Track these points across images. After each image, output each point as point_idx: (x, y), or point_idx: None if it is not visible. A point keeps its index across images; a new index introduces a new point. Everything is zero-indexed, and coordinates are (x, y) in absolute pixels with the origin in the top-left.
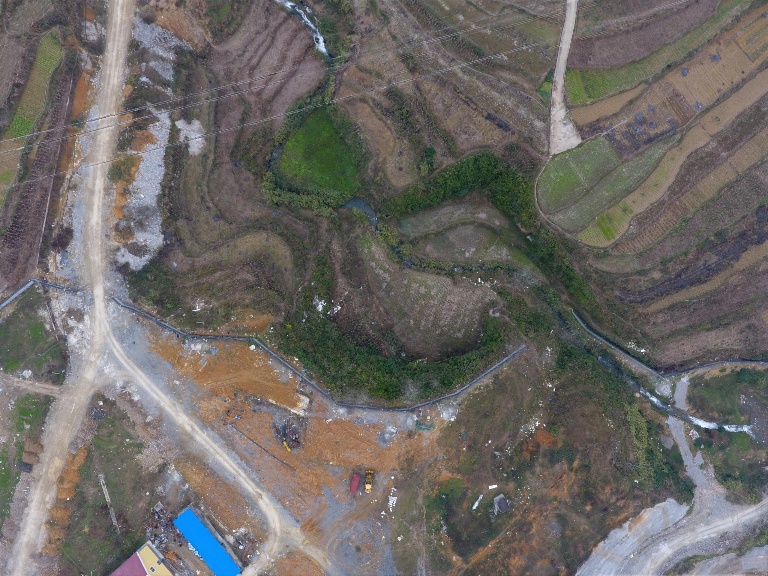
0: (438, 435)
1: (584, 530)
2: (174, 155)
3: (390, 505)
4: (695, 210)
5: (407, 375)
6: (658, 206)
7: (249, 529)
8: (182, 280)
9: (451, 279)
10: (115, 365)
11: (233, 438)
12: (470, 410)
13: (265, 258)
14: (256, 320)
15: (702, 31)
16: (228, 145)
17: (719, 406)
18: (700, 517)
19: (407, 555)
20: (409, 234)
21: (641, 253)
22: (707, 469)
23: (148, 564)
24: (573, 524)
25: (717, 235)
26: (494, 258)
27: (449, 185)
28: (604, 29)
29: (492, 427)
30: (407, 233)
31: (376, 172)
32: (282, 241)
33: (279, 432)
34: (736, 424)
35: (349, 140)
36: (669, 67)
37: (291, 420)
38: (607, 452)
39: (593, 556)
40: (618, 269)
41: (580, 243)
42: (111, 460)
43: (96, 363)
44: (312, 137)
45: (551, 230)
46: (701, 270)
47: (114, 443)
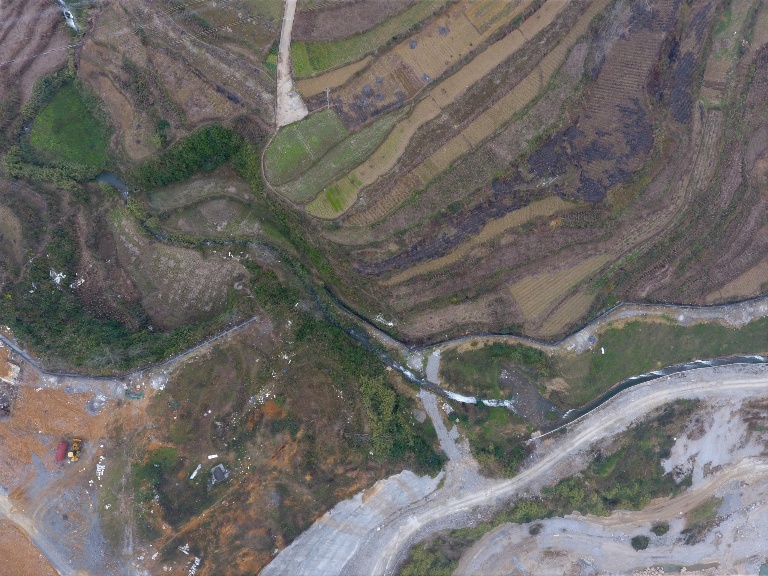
0: (147, 404)
1: (307, 500)
2: None
3: (98, 473)
4: (427, 182)
5: (121, 345)
6: (389, 178)
7: None
8: None
9: (200, 253)
10: None
11: None
12: (182, 379)
13: None
14: None
15: (428, 3)
16: None
17: (477, 381)
18: (452, 491)
19: (114, 523)
20: (159, 208)
21: (373, 225)
22: (462, 443)
23: None
24: (295, 494)
25: (450, 207)
26: (246, 232)
27: (187, 158)
28: (326, 1)
29: (211, 397)
30: (157, 207)
31: (117, 145)
32: (12, 213)
33: None
34: (496, 399)
35: (95, 114)
36: (395, 39)
37: (2, 389)
38: (334, 423)
39: (315, 526)
40: (351, 241)
41: (309, 215)
42: None
43: None
44: (62, 111)
45: (279, 202)
46: (440, 243)
47: None
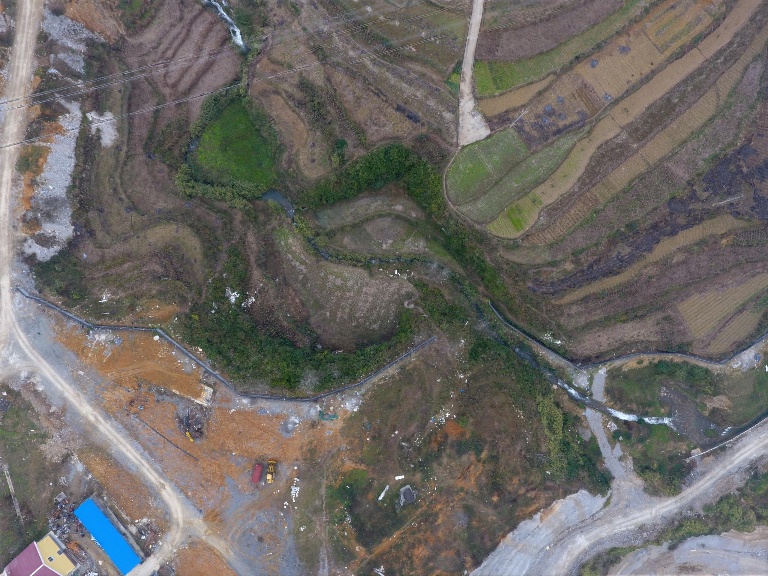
0: (341, 425)
1: (492, 521)
2: (85, 147)
3: (293, 495)
4: (606, 201)
5: (312, 366)
6: (568, 197)
7: (152, 519)
8: (91, 271)
9: (367, 271)
10: (20, 356)
11: (136, 428)
12: (374, 400)
13: (174, 249)
14: (162, 311)
15: (610, 23)
16: (141, 137)
17: (639, 398)
18: (618, 509)
19: (309, 545)
20: (326, 226)
21: (552, 244)
22: (626, 461)
23: (46, 554)
24: (480, 515)
25: (628, 226)
26: (411, 250)
27: (361, 177)
28: (511, 20)
29: (398, 418)
30: (324, 225)
31: (290, 164)
32: (192, 232)
33: (182, 422)
34: (656, 416)
35: (264, 132)
36: (577, 58)
37: (194, 410)
38: (516, 443)
39: (501, 547)
40: (529, 260)
41: (490, 234)
42: (15, 450)
43: (1, 354)
44: (229, 129)
45: (460, 221)
46: (614, 261)
47: (18, 433)
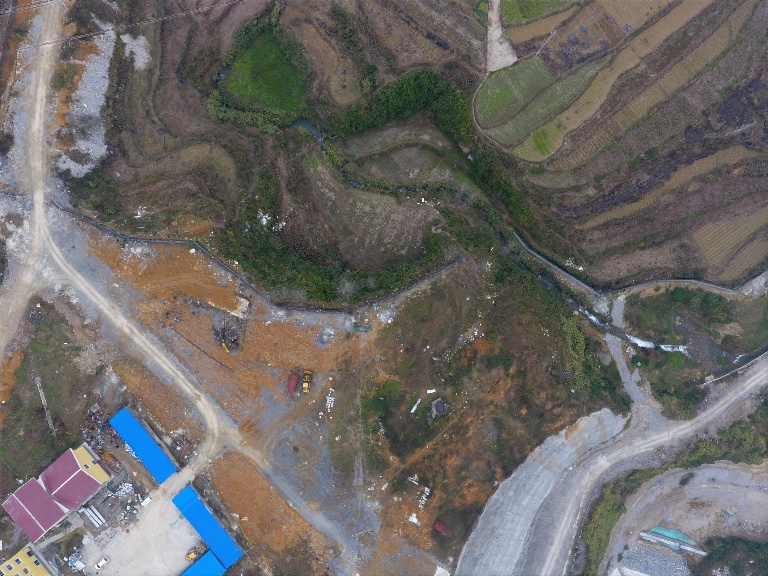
0: (375, 337)
1: (520, 434)
2: (119, 68)
3: (328, 406)
4: (626, 129)
5: None
6: (591, 124)
7: (187, 430)
8: (124, 189)
9: (395, 198)
10: (54, 269)
11: (172, 340)
12: (407, 313)
13: (208, 168)
14: (197, 226)
15: None
16: (174, 61)
17: (655, 326)
18: (637, 431)
19: (344, 455)
20: (354, 154)
21: (575, 169)
22: (644, 386)
23: (82, 461)
24: (509, 428)
25: (647, 153)
26: (437, 179)
27: (391, 103)
28: None
29: (430, 332)
30: (352, 153)
31: (320, 91)
32: (225, 153)
33: (218, 334)
34: (672, 344)
35: (295, 61)
36: None
37: (230, 322)
38: (543, 359)
39: (529, 460)
40: (554, 185)
41: (516, 158)
42: (48, 363)
43: (34, 267)
44: (259, 59)
45: (488, 145)
46: (634, 188)
47: (52, 346)
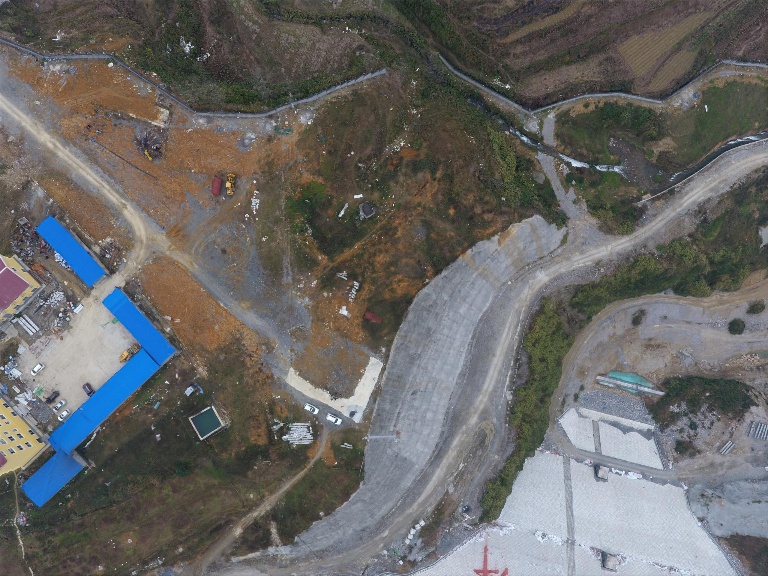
0: (297, 138)
1: (450, 236)
2: None
3: (253, 207)
4: None
5: None
6: None
7: (115, 238)
8: (43, 16)
9: (319, 28)
10: None
11: (95, 152)
12: (328, 116)
13: None
14: (115, 43)
15: None
16: None
17: (589, 146)
18: (575, 247)
19: (272, 254)
20: None
21: None
22: (580, 204)
23: (9, 264)
24: (439, 230)
25: None
26: (361, 8)
27: None
28: None
29: (353, 138)
30: None
31: None
32: None
33: (140, 143)
34: (607, 164)
35: None
36: None
37: (152, 132)
38: (469, 164)
39: (460, 260)
40: None
41: None
42: None
43: None
44: None
45: None
46: None
47: None
